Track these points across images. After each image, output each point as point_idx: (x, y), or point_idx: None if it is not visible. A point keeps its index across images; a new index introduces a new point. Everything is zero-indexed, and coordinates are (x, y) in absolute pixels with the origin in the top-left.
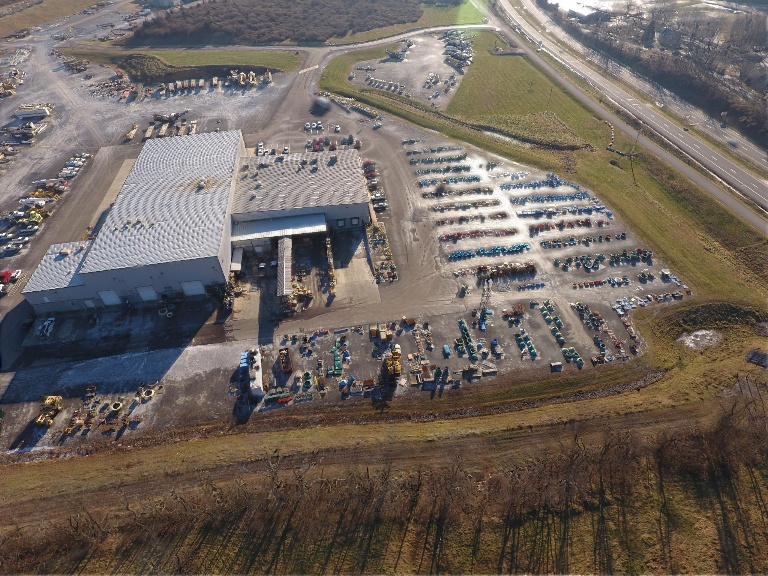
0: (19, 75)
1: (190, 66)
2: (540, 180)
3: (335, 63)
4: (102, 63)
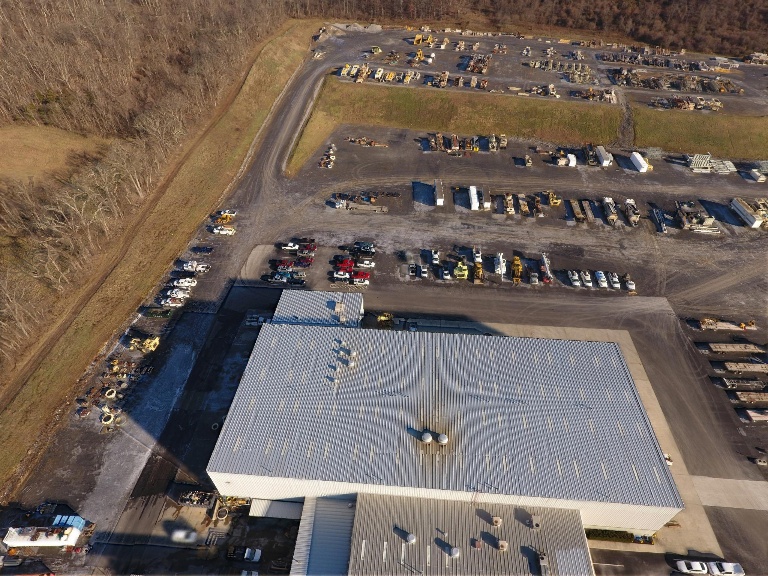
0: None
1: None
2: None
3: None
4: None
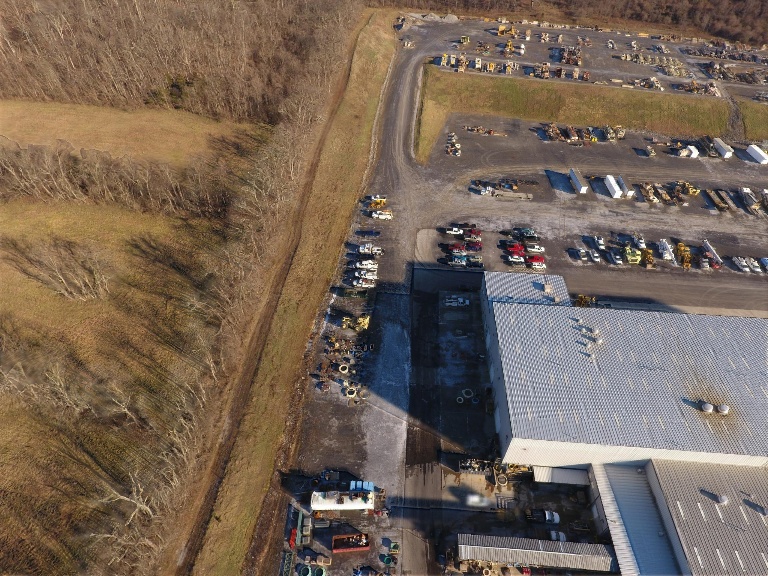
0: None
1: None
2: None
3: None
4: None
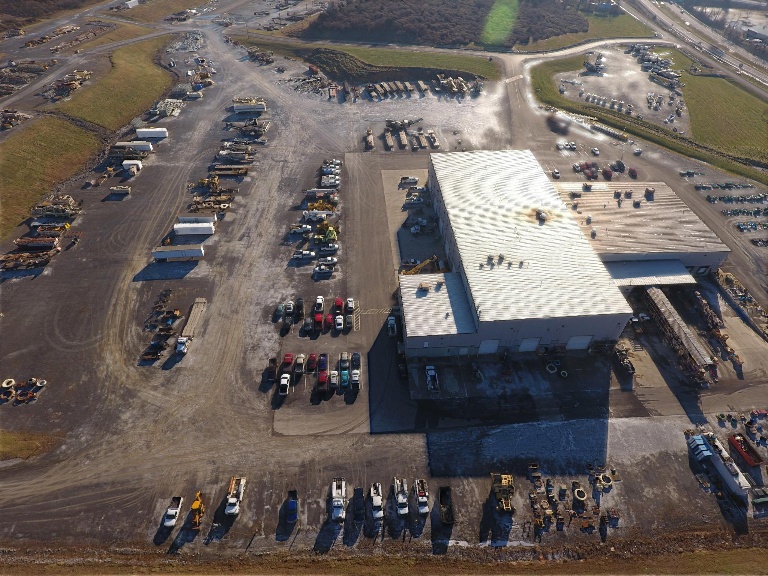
0: (206, 63)
1: (391, 66)
2: None
3: (538, 73)
4: (286, 55)
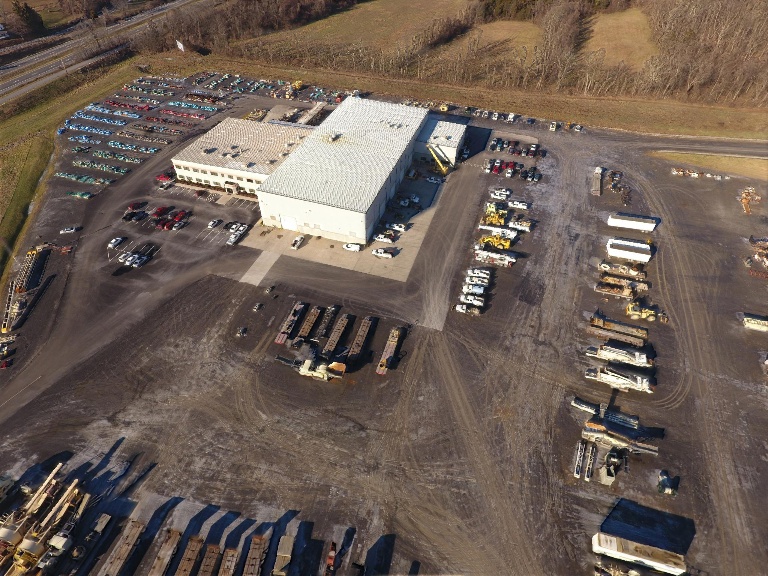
0: None
1: None
2: (76, 131)
3: None
4: None
